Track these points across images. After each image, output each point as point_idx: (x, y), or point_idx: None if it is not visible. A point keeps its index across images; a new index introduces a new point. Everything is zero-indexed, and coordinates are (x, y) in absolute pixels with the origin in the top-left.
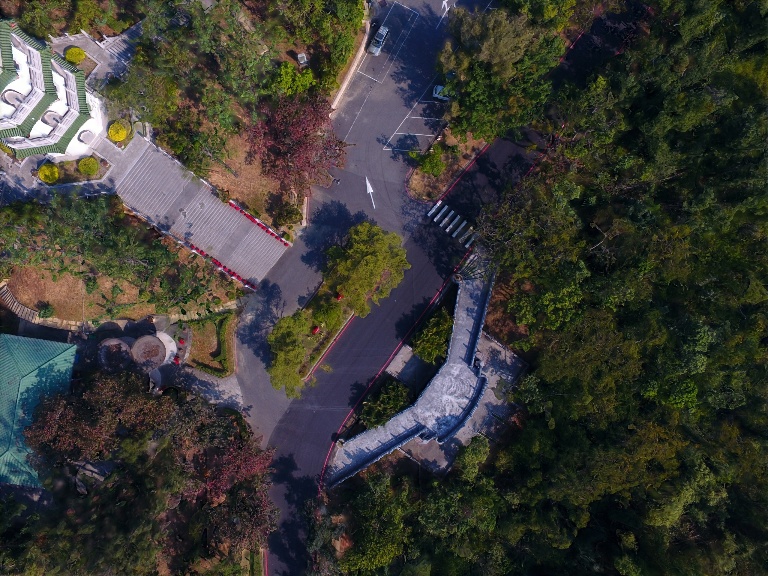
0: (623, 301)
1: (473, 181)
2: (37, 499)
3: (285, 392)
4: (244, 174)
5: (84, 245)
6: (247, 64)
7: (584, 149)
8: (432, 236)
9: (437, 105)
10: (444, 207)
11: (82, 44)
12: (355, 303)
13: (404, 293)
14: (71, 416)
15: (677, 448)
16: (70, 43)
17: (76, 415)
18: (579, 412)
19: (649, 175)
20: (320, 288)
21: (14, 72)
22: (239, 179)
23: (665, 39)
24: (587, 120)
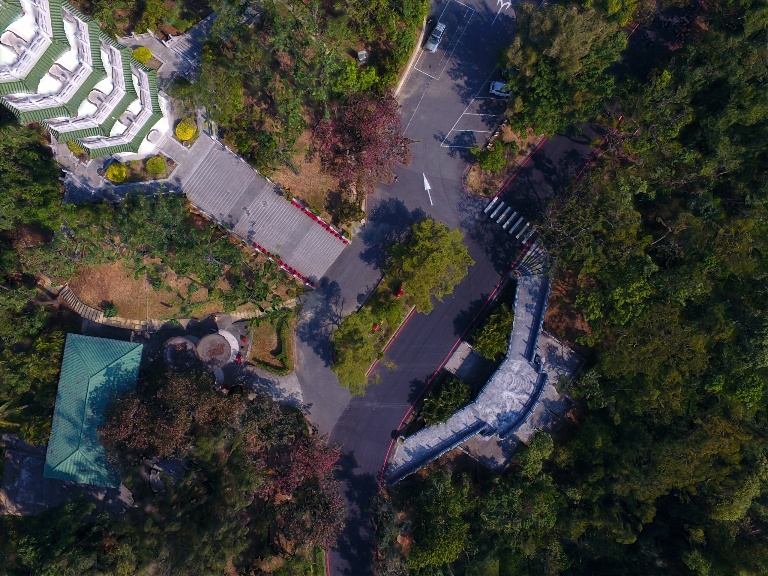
0: (692, 295)
1: (529, 177)
2: (102, 498)
3: (345, 390)
4: (304, 172)
5: (155, 244)
6: (325, 61)
7: (646, 144)
8: (489, 232)
9: (494, 101)
10: (500, 203)
11: (147, 43)
12: (418, 300)
13: (462, 290)
14: (145, 415)
15: (741, 442)
16: (135, 43)
17: (149, 414)
18: (643, 407)
19: (708, 169)
20: (379, 285)
21: (104, 71)
22: (299, 177)
23: (724, 33)
24: (652, 114)
